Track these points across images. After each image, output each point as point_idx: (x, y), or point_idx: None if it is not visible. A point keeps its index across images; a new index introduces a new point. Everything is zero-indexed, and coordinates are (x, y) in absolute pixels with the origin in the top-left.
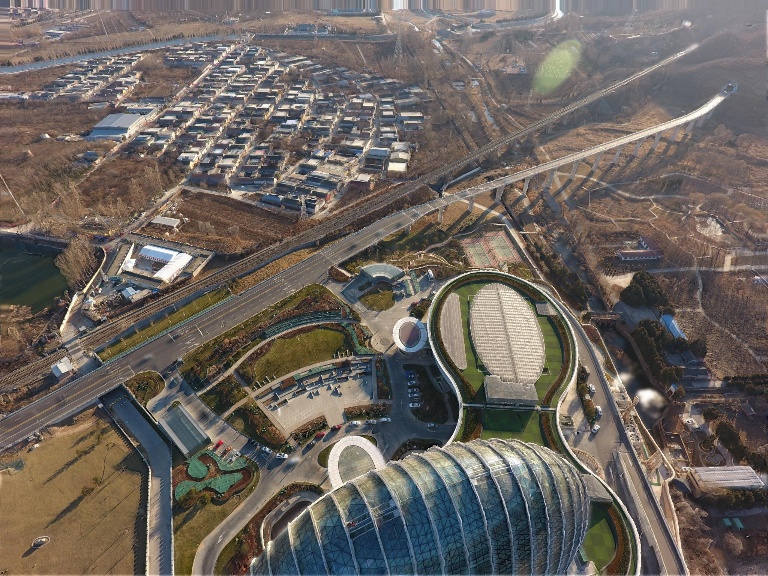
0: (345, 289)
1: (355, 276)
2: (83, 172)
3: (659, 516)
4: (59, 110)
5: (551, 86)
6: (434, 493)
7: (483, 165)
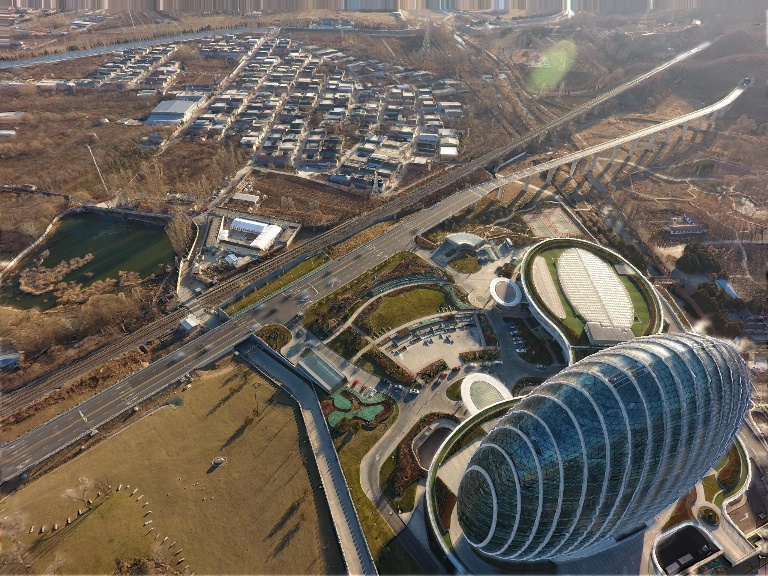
0: (433, 255)
1: (440, 244)
2: (153, 153)
3: (753, 434)
4: (109, 97)
5: (576, 79)
6: (670, 357)
7: (527, 150)
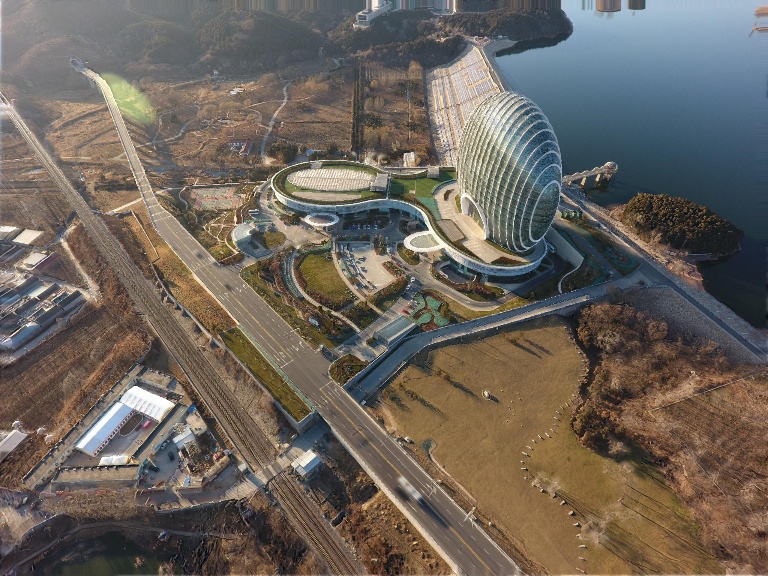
0: (253, 256)
1: None
2: None
3: None
4: None
5: None
6: None
7: None
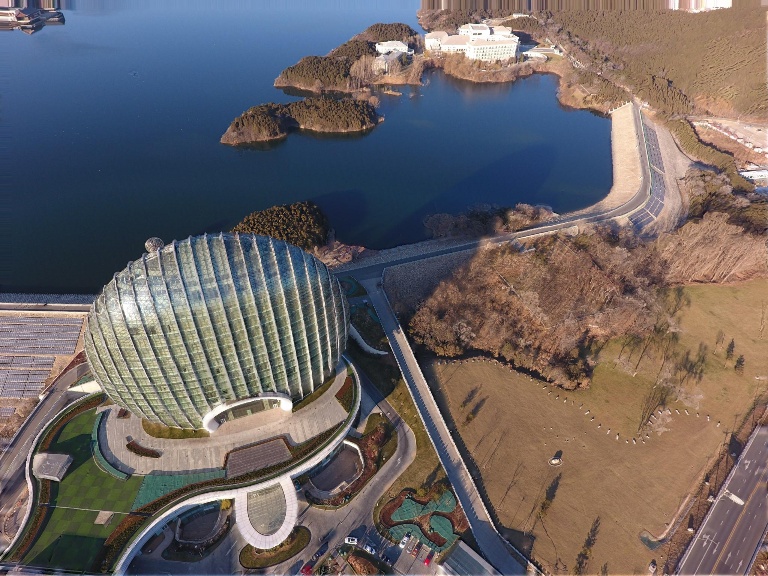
0: None
1: None
2: None
3: (1, 463)
4: None
5: None
6: None
7: None
